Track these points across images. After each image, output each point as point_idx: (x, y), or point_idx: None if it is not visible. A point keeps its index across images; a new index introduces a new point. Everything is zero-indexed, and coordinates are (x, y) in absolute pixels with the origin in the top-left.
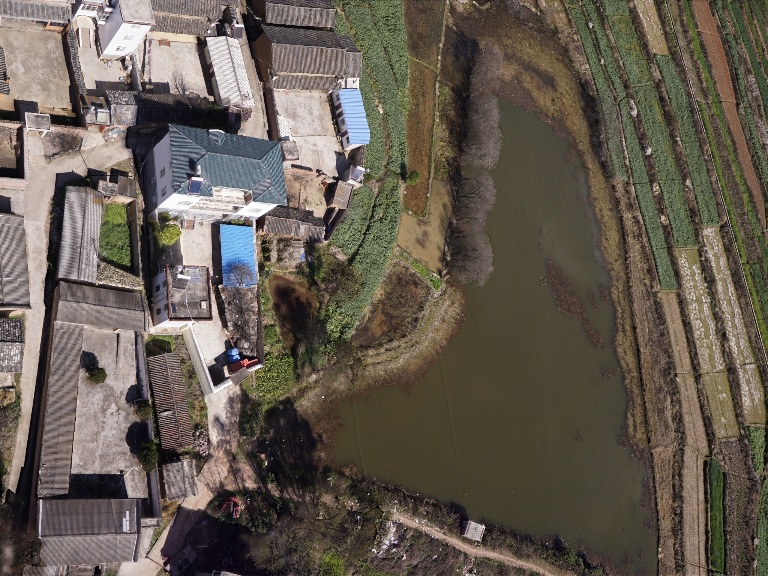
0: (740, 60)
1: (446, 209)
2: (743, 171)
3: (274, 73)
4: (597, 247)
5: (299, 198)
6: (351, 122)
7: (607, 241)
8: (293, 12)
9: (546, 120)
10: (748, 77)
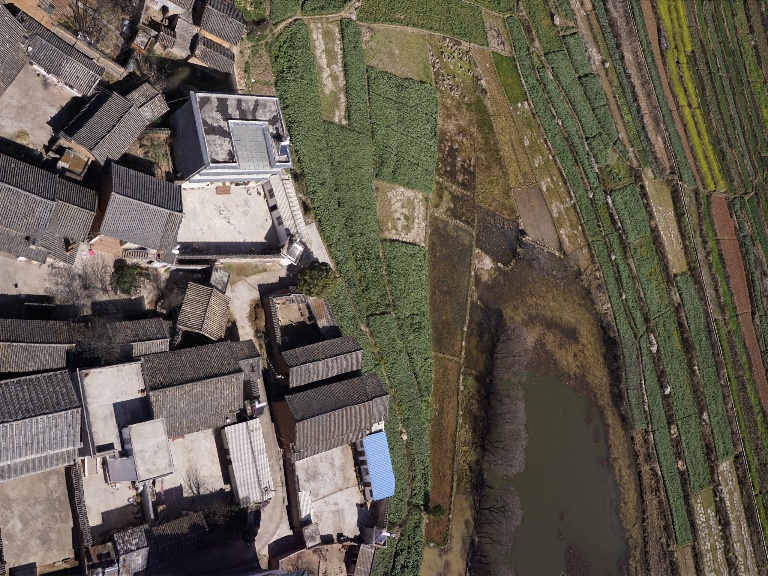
0: (756, 263)
1: (468, 526)
2: (757, 390)
3: None
4: (616, 516)
5: (318, 573)
6: (375, 474)
7: (625, 505)
8: (318, 367)
9: (568, 382)
10: (764, 280)
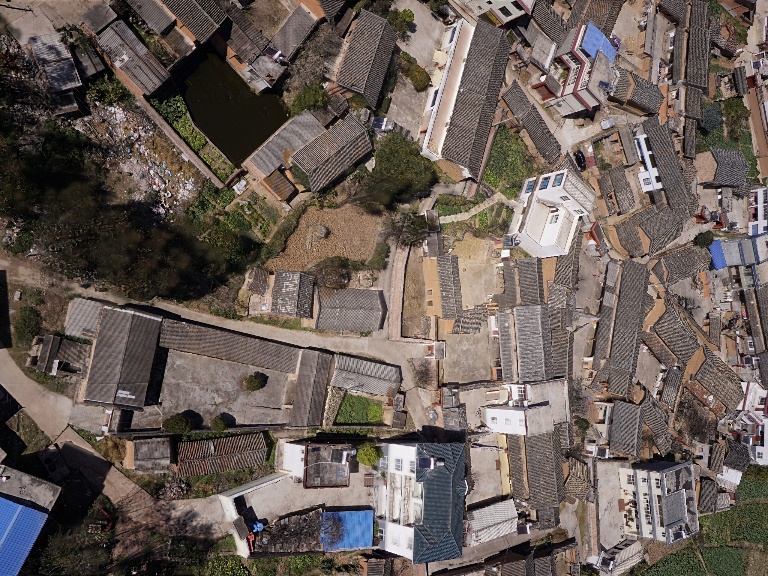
0: None
1: None
2: None
3: (499, 567)
4: None
5: None
6: None
7: None
8: None
9: None
10: None
